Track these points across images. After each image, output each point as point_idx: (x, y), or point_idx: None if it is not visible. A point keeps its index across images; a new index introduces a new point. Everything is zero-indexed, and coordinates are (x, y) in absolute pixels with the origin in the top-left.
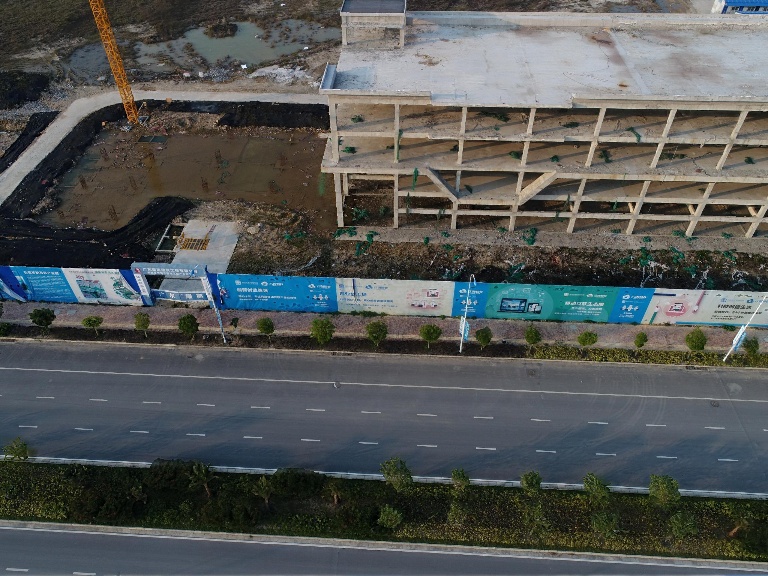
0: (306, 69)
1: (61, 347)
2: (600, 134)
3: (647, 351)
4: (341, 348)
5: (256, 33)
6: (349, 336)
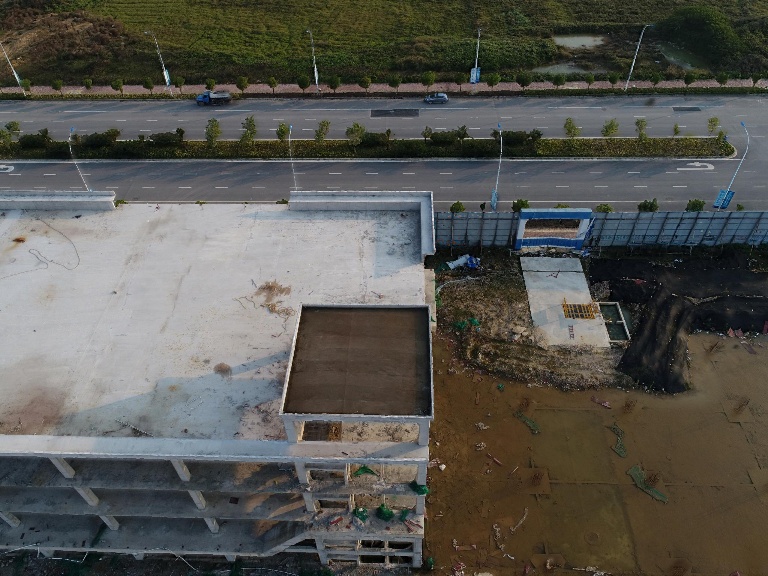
0: None
1: None
2: None
3: None
4: None
5: None
6: None
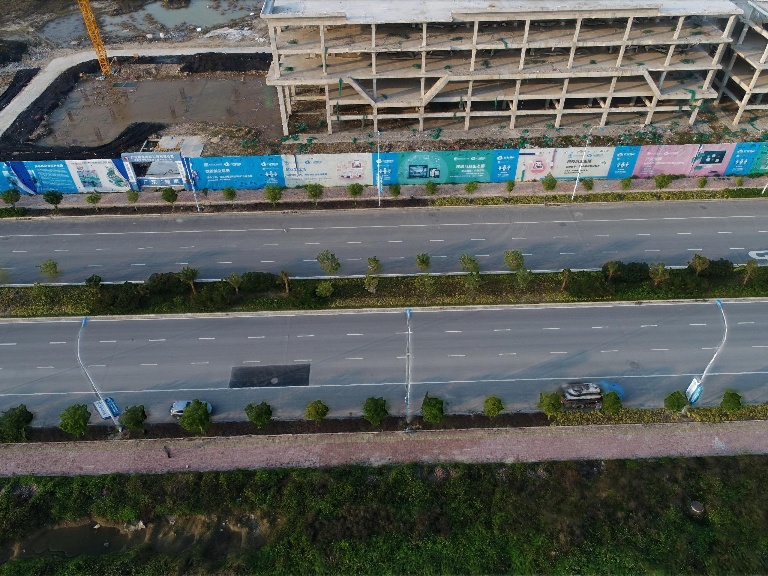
0: (253, 29)
1: (69, 221)
2: (477, 43)
3: (517, 197)
4: (289, 209)
5: (207, 4)
6: (295, 201)
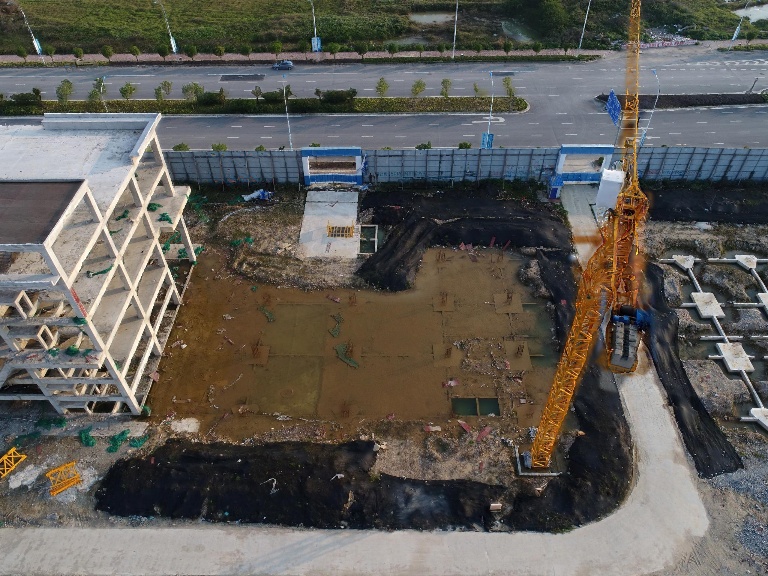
0: None
1: None
2: None
3: None
4: None
5: None
6: None
